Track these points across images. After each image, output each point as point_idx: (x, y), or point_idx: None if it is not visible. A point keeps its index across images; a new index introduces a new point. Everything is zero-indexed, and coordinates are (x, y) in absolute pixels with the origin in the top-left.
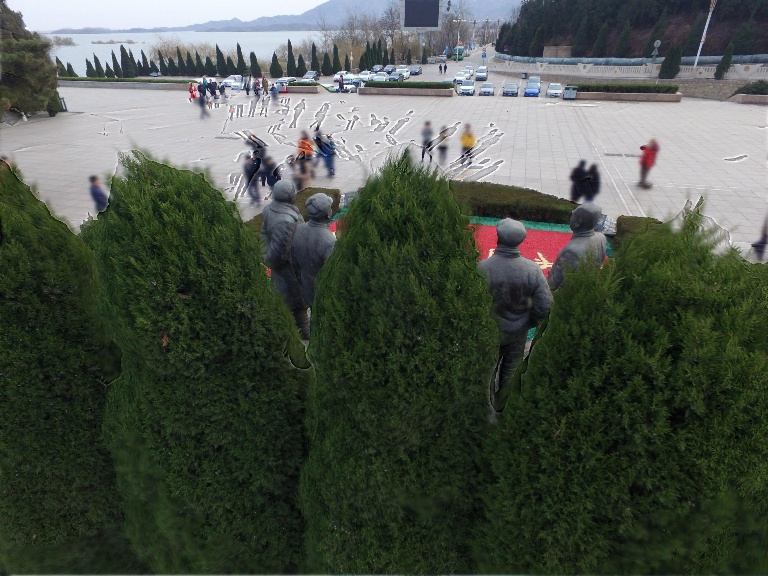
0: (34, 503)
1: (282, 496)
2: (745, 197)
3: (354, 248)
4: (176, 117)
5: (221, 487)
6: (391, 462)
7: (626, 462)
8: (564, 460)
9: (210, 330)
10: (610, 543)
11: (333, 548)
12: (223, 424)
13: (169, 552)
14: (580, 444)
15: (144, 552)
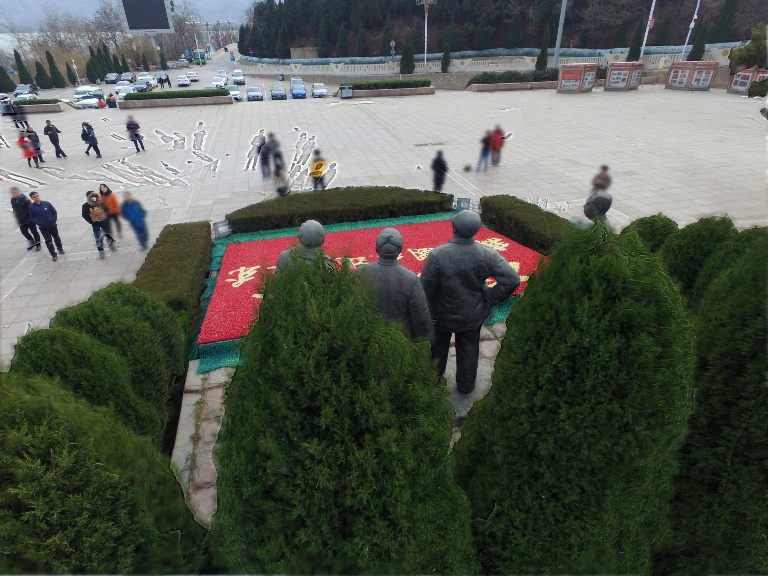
0: None
1: None
2: (535, 166)
3: None
4: None
5: None
6: None
7: None
8: None
9: None
10: None
11: (767, 555)
12: None
13: None
14: None
15: None
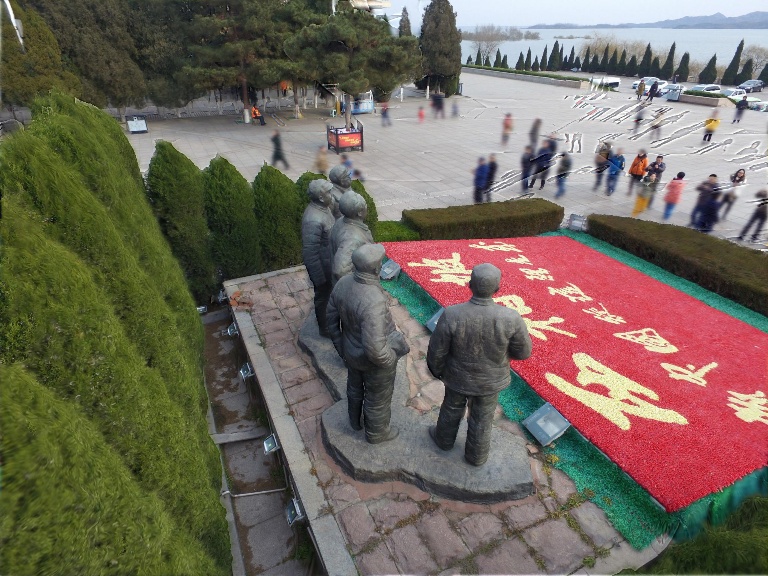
0: None
1: None
2: None
3: None
4: (533, 111)
5: None
6: None
7: None
8: None
9: None
10: None
11: None
12: None
13: None
14: None
15: None
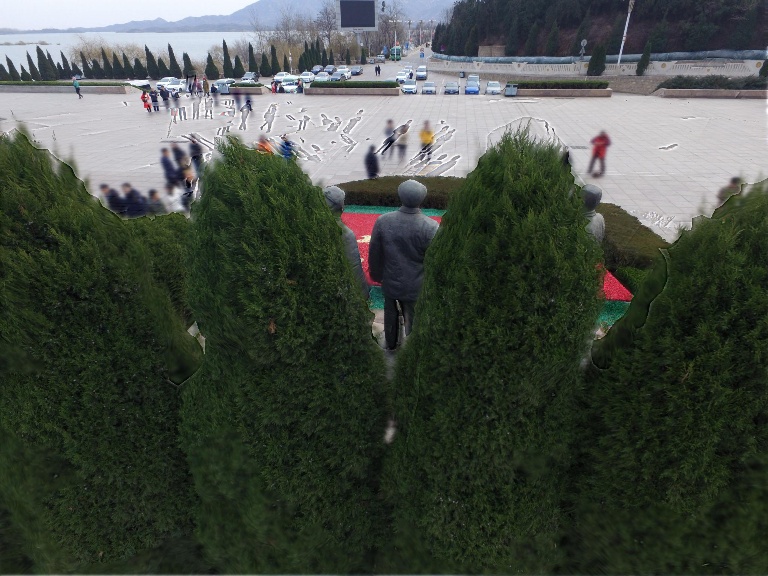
0: (102, 517)
1: (366, 480)
2: (683, 181)
3: (489, 218)
4: (113, 121)
5: (314, 475)
6: (510, 425)
7: (754, 394)
8: (692, 400)
9: (312, 315)
10: (731, 472)
11: (441, 519)
12: (318, 411)
13: (254, 550)
14: (709, 383)
15: (221, 555)
